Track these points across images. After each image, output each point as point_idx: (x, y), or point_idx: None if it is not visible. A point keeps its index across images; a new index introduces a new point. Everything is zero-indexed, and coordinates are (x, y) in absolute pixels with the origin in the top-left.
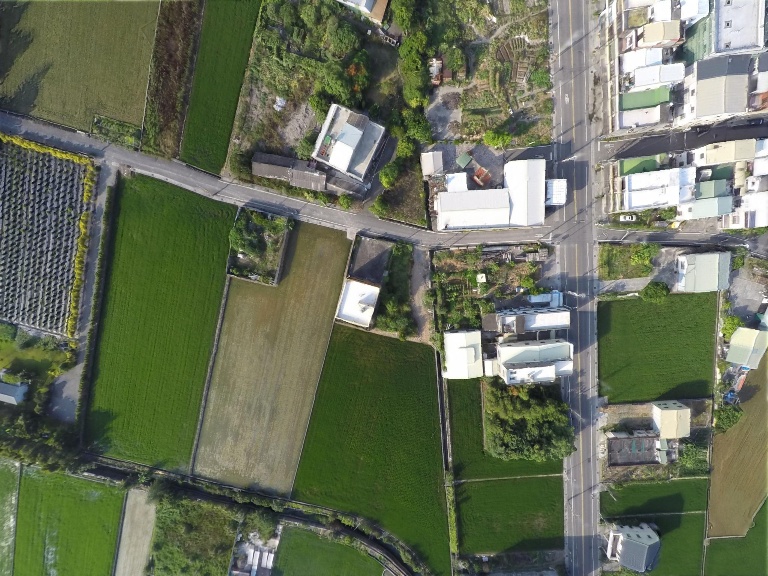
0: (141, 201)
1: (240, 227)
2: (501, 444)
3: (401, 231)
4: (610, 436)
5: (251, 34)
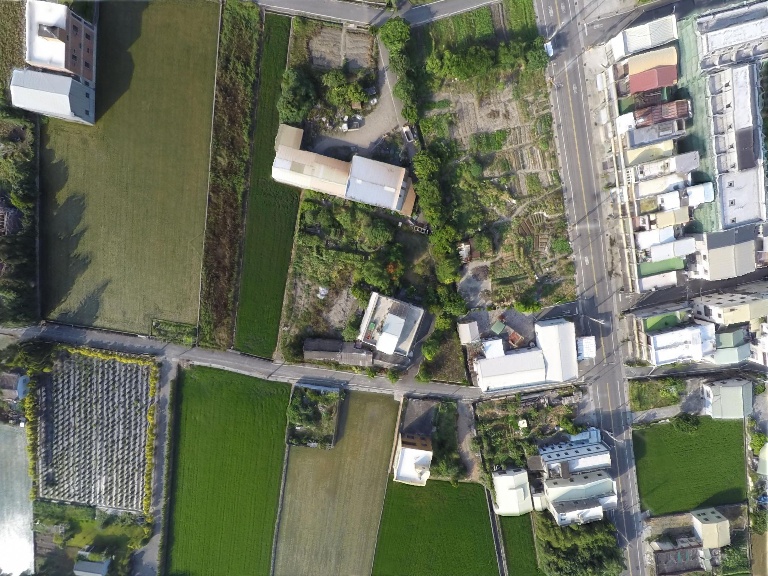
0: (201, 388)
1: (296, 404)
2: (556, 569)
3: (444, 389)
4: (656, 548)
5: (291, 236)
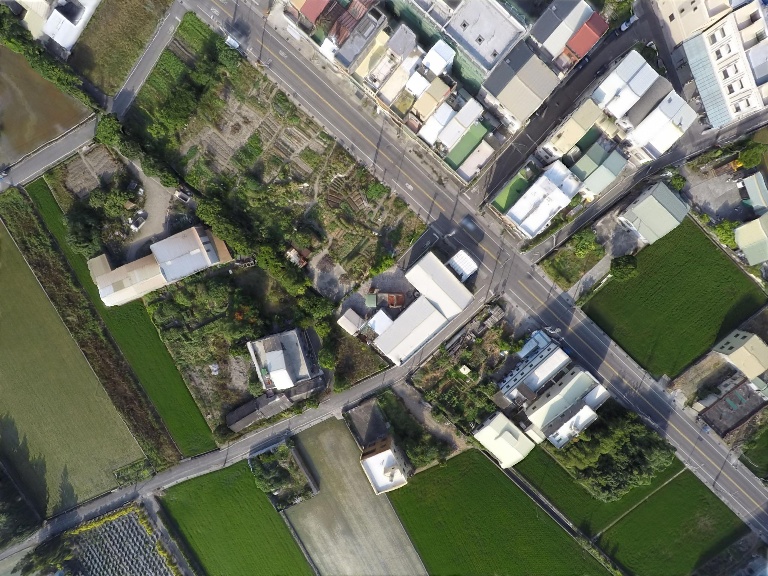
0: (184, 504)
1: (259, 474)
2: (602, 490)
3: (372, 384)
4: (699, 409)
5: (160, 340)
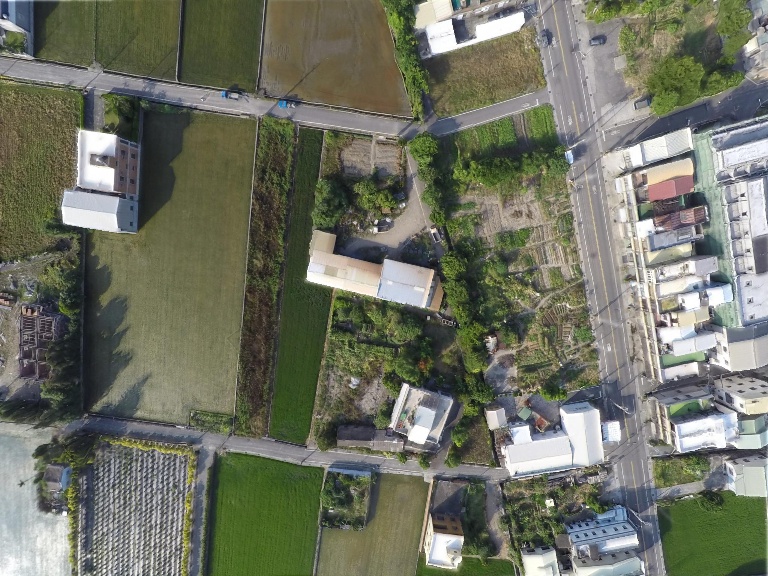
0: (237, 474)
1: (329, 489)
2: None
3: (473, 471)
4: None
5: (324, 331)
